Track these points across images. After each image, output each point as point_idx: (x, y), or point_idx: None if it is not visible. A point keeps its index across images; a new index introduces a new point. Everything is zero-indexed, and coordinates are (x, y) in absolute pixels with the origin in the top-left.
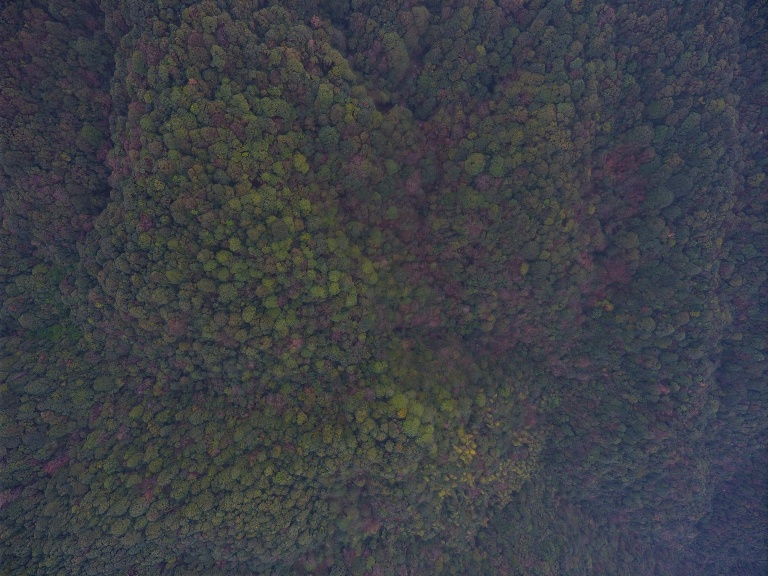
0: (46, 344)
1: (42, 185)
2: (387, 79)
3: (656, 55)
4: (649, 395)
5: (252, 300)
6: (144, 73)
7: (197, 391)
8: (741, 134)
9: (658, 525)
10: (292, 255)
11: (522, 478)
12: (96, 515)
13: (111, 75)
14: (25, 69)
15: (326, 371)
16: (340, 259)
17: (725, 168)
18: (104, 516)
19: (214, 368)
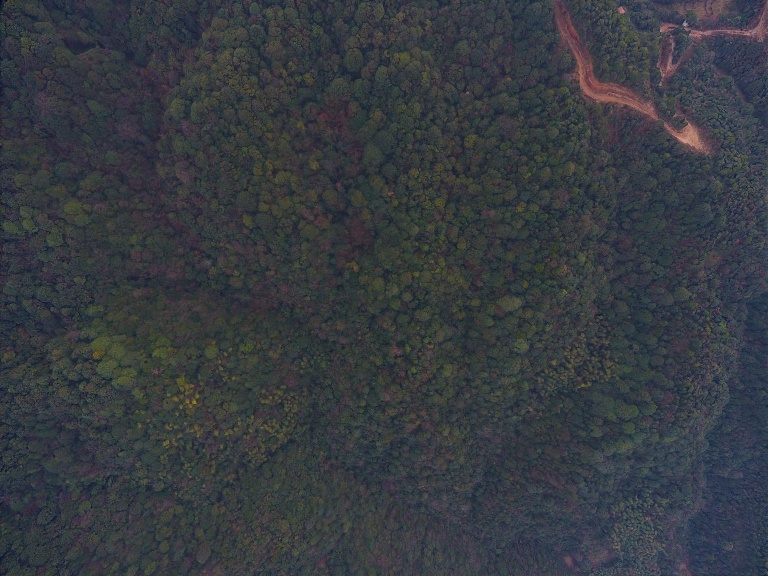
0: None
1: None
2: (93, 21)
3: (333, 4)
4: (387, 357)
5: None
6: None
7: None
8: (445, 93)
9: (425, 494)
10: None
11: (279, 438)
12: None
13: None
14: None
15: (36, 311)
16: (29, 195)
17: (429, 126)
18: None
19: None
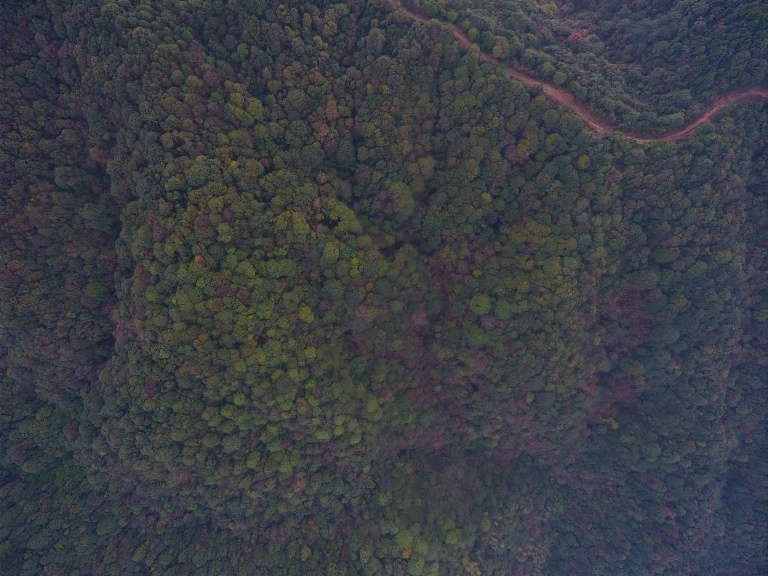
0: (49, 489)
1: (47, 343)
2: (392, 220)
3: (663, 209)
4: (655, 516)
5: (256, 445)
6: (150, 246)
7: (200, 525)
8: (747, 275)
9: None
10: (297, 405)
11: None
12: None
13: (116, 233)
14: (31, 241)
15: (330, 505)
16: (345, 405)
17: (731, 308)
18: None
19: (218, 509)
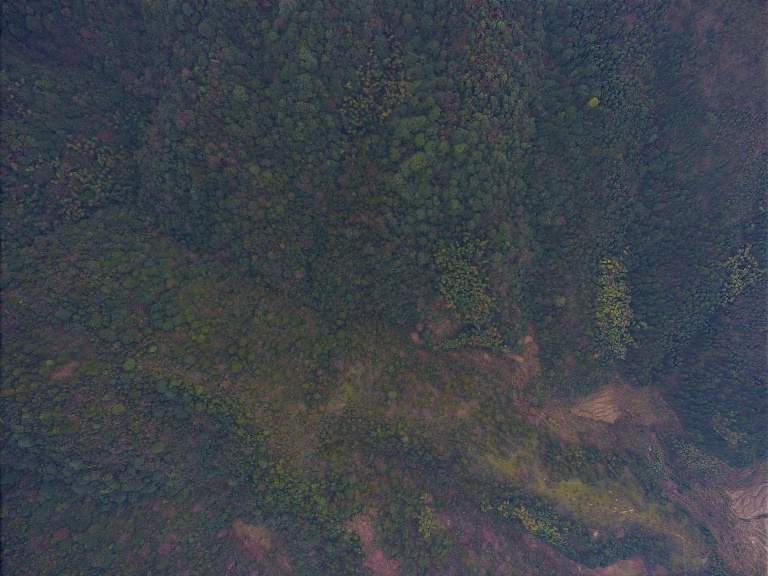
0: None
1: None
2: None
3: None
4: None
5: None
6: None
7: None
8: None
9: (253, 256)
10: None
11: (96, 193)
12: None
13: None
14: None
15: None
16: None
17: None
18: None
19: None
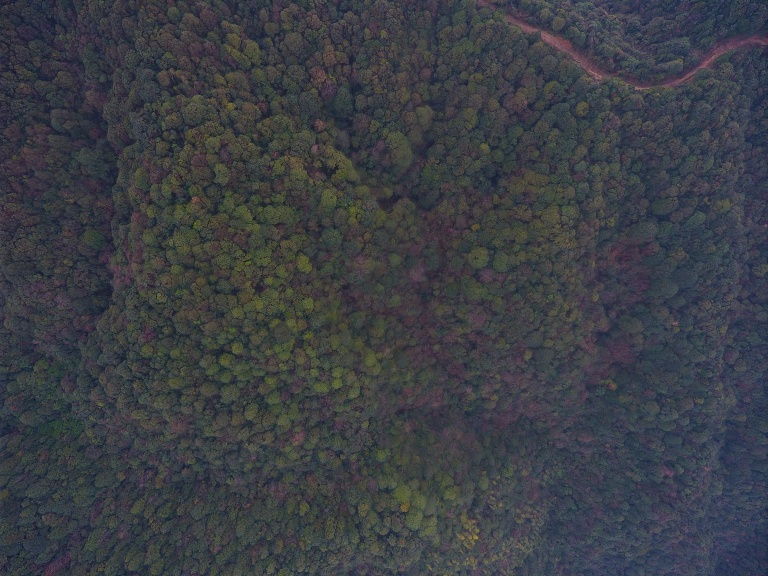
0: (47, 441)
1: (44, 291)
2: (390, 173)
3: (661, 158)
4: (653, 476)
5: (254, 397)
6: (147, 188)
7: (199, 481)
8: (746, 228)
9: None
10: (295, 355)
11: (525, 552)
12: None
13: (113, 180)
14: (27, 184)
15: (328, 461)
16: (343, 356)
17: (730, 261)
18: None
19: (216, 462)
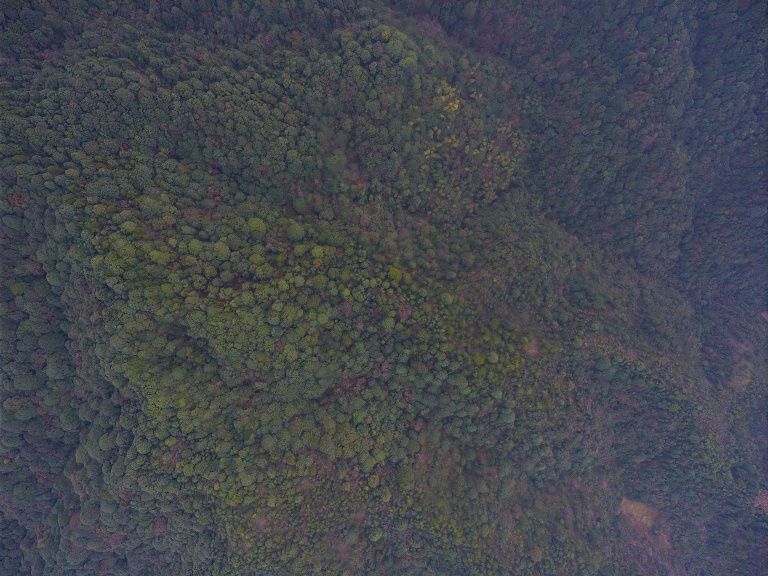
0: None
1: None
2: None
3: None
4: (627, 67)
5: None
6: None
7: (188, 29)
8: None
9: (640, 236)
10: None
11: (507, 176)
12: (91, 72)
13: None
14: None
15: (313, 9)
16: None
17: None
18: (98, 74)
19: None
